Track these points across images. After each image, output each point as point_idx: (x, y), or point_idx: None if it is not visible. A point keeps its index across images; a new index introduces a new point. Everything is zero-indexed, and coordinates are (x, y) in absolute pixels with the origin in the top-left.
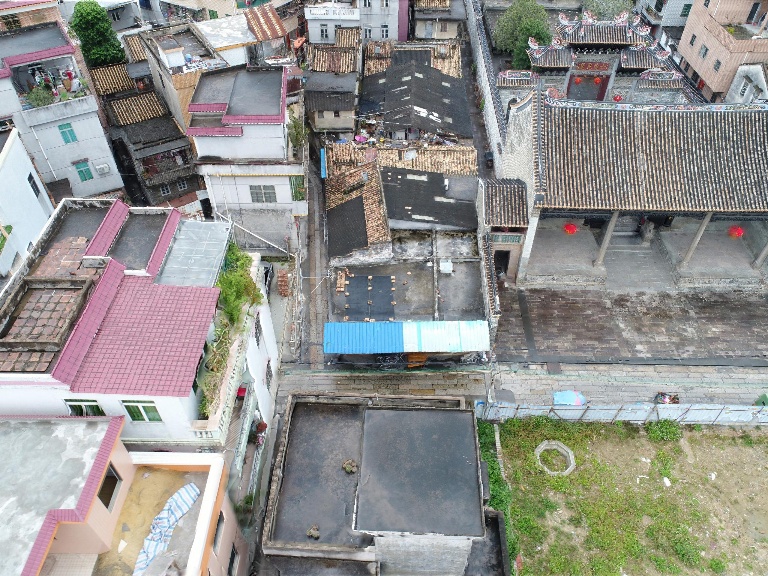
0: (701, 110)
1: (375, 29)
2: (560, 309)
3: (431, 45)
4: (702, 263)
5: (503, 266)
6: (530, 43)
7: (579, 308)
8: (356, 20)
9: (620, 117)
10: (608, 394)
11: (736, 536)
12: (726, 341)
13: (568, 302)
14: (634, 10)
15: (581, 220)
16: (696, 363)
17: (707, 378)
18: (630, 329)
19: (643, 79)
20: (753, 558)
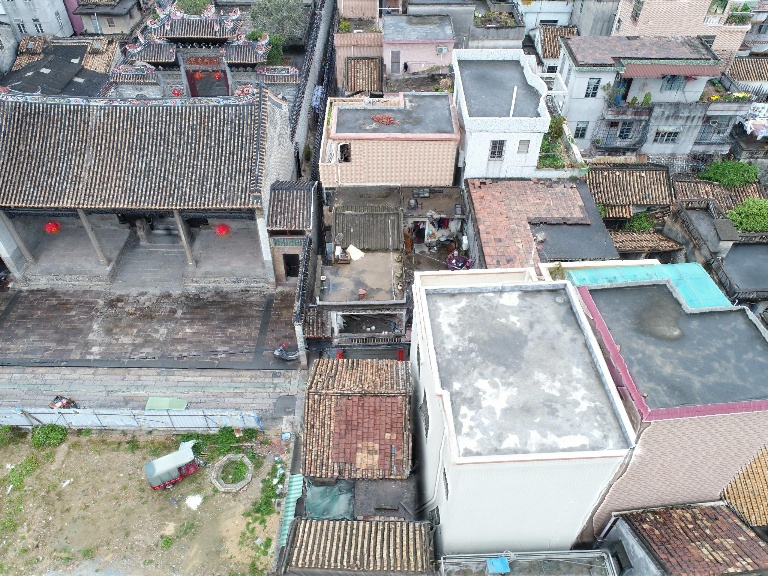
0: (158, 104)
1: (28, 24)
2: (45, 310)
3: (87, 40)
4: (215, 262)
5: (5, 266)
6: (139, 37)
7: (66, 309)
8: (2, 14)
9: (75, 112)
10: (24, 398)
11: (33, 546)
12: (190, 342)
13: (60, 303)
14: (318, 5)
15: (114, 218)
16: (140, 365)
17: (141, 381)
18: (101, 330)
19: (260, 74)
20: (29, 569)
